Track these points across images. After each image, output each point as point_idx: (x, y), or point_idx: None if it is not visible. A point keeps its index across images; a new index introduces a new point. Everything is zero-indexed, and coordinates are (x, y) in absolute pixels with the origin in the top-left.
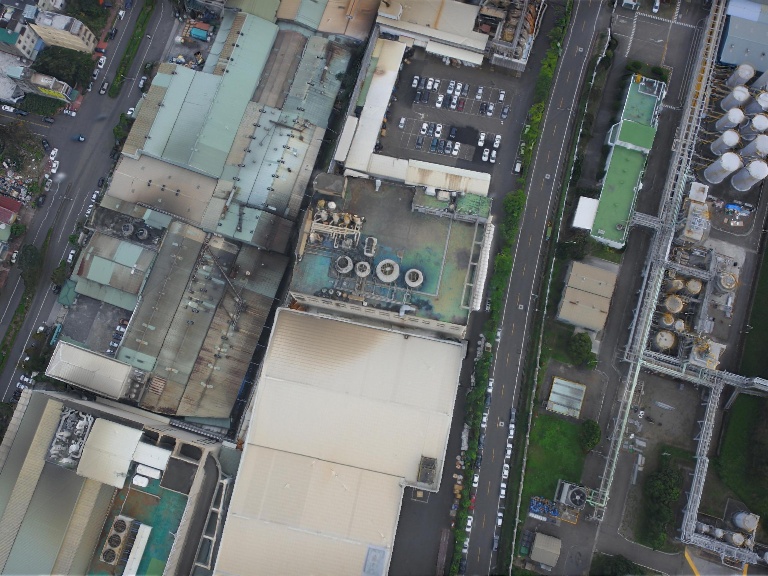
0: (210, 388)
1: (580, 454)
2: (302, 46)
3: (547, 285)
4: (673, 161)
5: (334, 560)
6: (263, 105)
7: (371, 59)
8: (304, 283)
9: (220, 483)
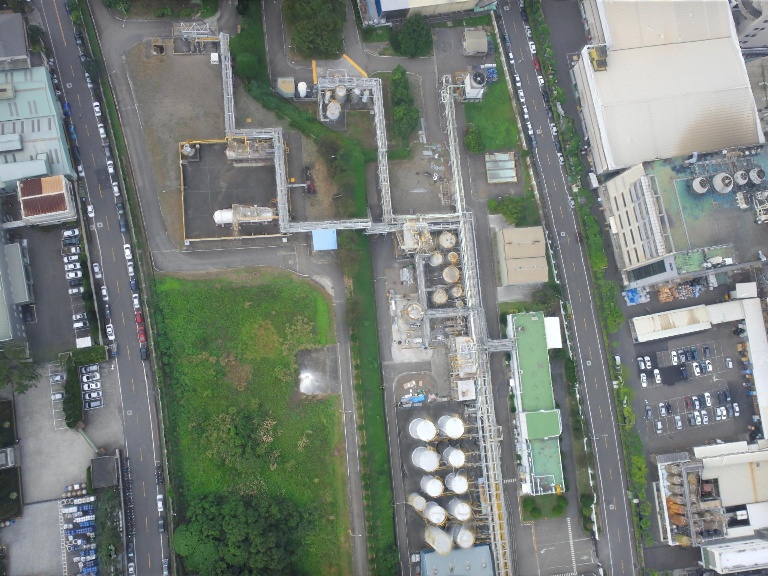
0: (761, 83)
1: None
2: None
3: None
4: None
5: None
6: None
7: None
8: None
9: (737, 1)
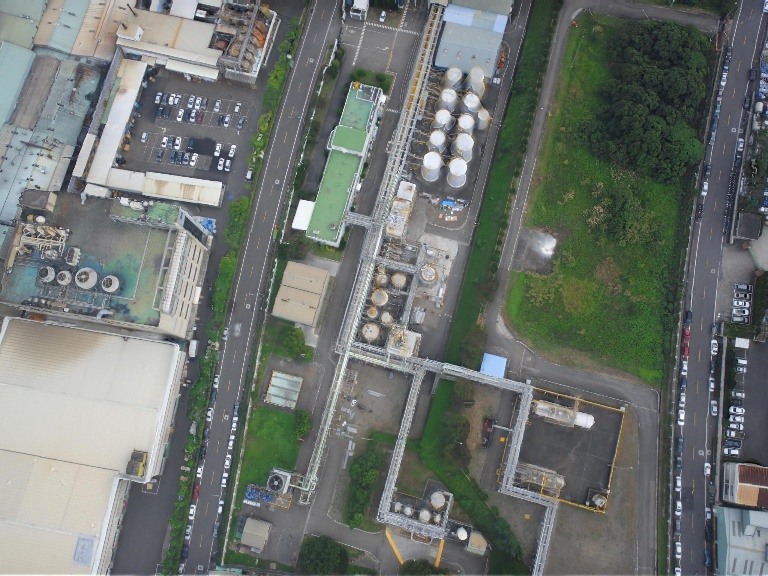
0: None
1: (295, 442)
2: (56, 69)
3: (270, 285)
4: (387, 162)
5: (47, 550)
6: (15, 127)
7: (115, 79)
8: (13, 293)
9: None
